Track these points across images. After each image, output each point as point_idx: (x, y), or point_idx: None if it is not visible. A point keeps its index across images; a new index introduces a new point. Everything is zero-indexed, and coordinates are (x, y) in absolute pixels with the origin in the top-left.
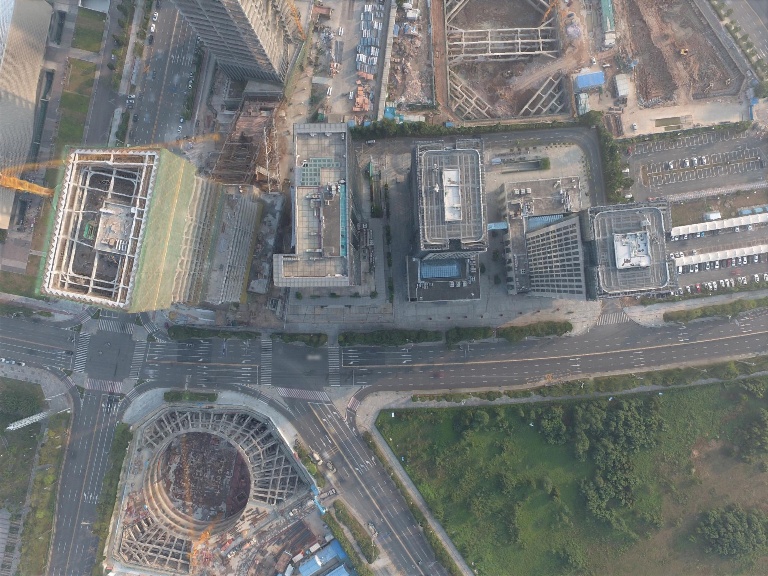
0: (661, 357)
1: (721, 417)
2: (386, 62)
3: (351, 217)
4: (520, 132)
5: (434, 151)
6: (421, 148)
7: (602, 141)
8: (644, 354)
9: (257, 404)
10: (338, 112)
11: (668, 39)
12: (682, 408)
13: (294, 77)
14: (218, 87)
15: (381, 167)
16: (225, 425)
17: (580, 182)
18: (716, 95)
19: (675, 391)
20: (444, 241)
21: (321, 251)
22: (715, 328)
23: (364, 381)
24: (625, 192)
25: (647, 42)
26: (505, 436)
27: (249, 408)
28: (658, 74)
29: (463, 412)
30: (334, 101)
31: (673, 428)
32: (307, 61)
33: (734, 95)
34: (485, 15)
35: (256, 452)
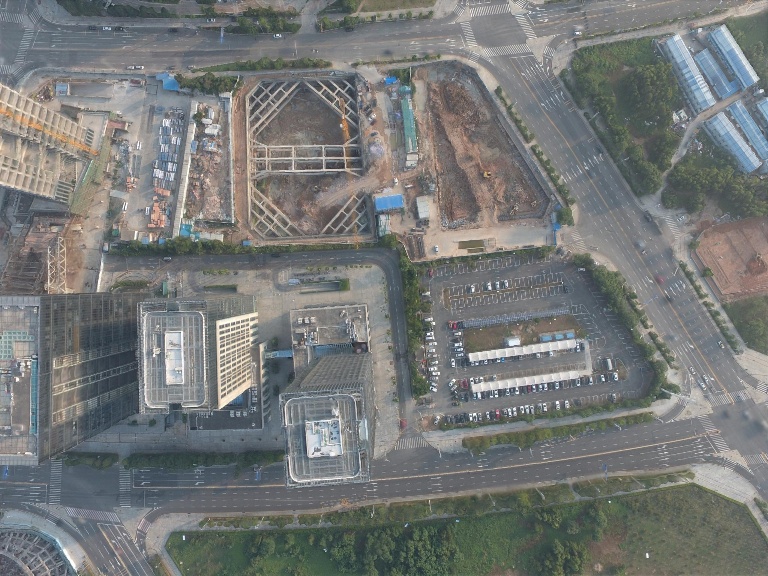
0: (459, 483)
1: (518, 546)
2: (182, 179)
3: (93, 365)
4: (320, 251)
5: (156, 312)
6: (144, 308)
7: (398, 266)
8: (442, 480)
9: (45, 524)
10: (134, 227)
11: (473, 160)
12: (478, 536)
13: (85, 193)
14: (13, 198)
15: (177, 284)
16: (13, 544)
17: (380, 303)
18: (522, 217)
19: (472, 519)
20: (165, 405)
21: (10, 428)
22: (515, 454)
23: (155, 502)
24: (426, 315)
25: (453, 162)
26: (298, 561)
27: (35, 529)
28: (464, 194)
29: (255, 537)
30: (130, 216)
31: (468, 557)
32: (104, 174)
33: (539, 218)
34: (299, 125)
35: (44, 573)
